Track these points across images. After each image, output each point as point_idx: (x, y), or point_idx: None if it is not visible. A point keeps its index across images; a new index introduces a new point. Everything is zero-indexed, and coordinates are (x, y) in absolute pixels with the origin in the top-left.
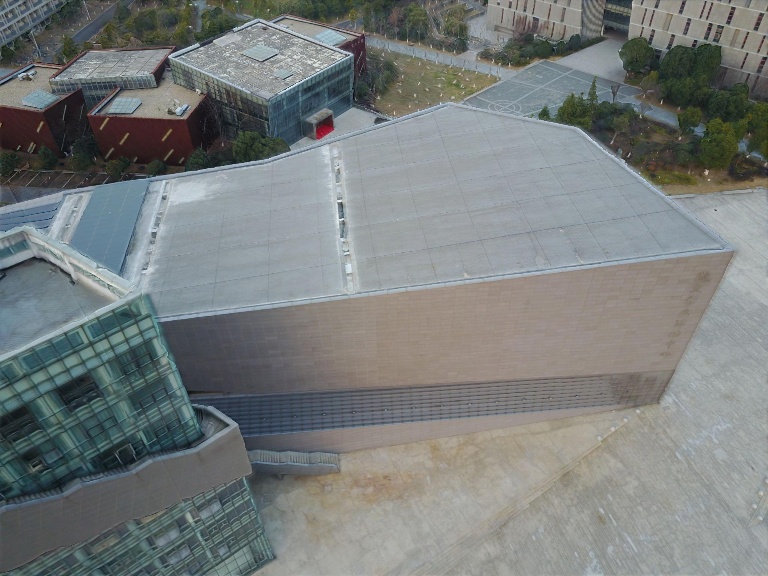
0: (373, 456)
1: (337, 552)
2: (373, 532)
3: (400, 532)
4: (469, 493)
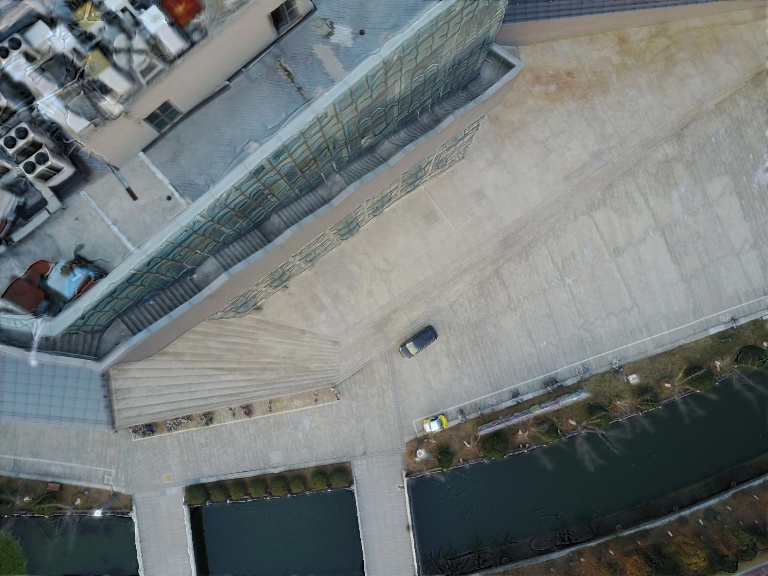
0: (555, 49)
1: (522, 153)
2: (557, 133)
3: (584, 134)
4: (656, 94)
